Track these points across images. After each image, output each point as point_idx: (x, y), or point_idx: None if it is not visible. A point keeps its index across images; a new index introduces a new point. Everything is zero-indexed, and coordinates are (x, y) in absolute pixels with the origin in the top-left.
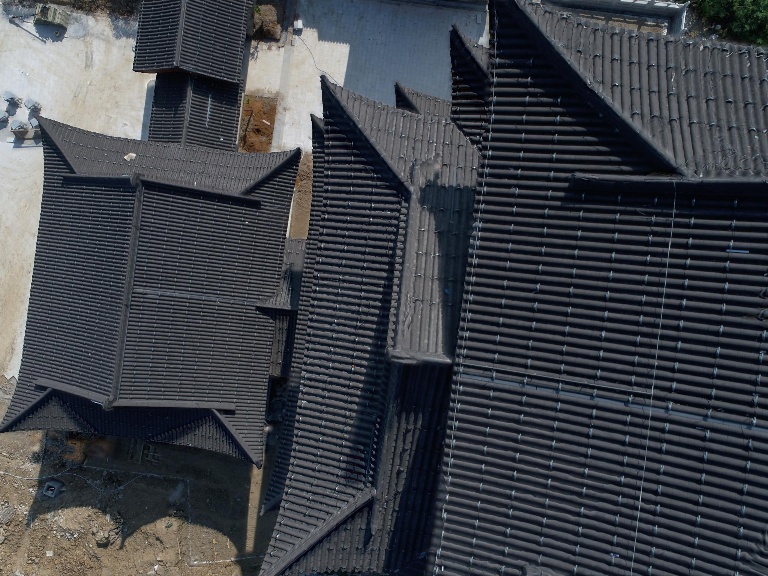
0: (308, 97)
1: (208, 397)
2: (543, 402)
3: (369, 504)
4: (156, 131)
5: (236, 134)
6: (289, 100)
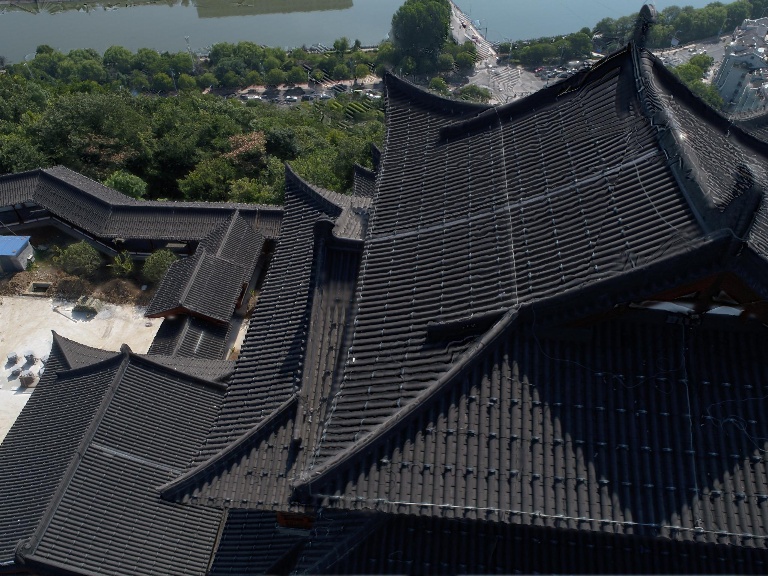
0: None
1: (134, 575)
2: None
3: (294, 411)
4: None
5: None
6: None
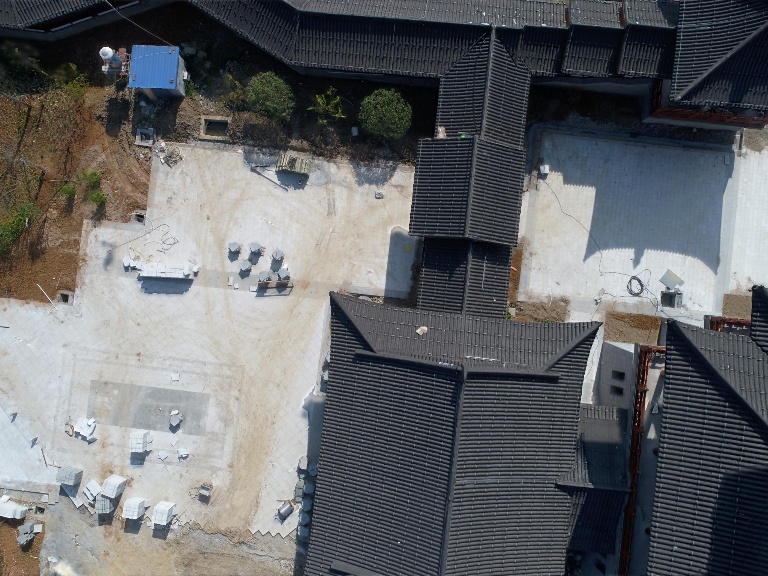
0: (554, 242)
1: None
2: None
3: None
4: (427, 292)
5: (507, 293)
6: (535, 245)
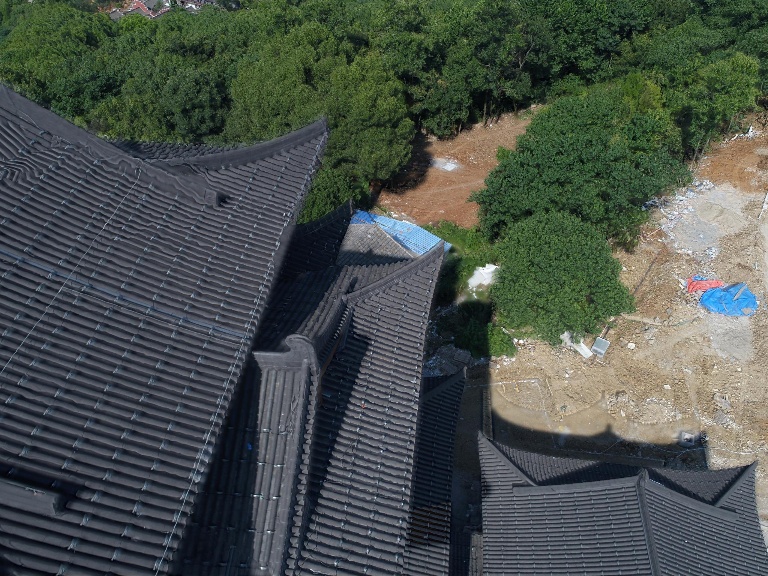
0: None
1: (544, 499)
2: (169, 303)
3: None
4: None
5: None
6: None
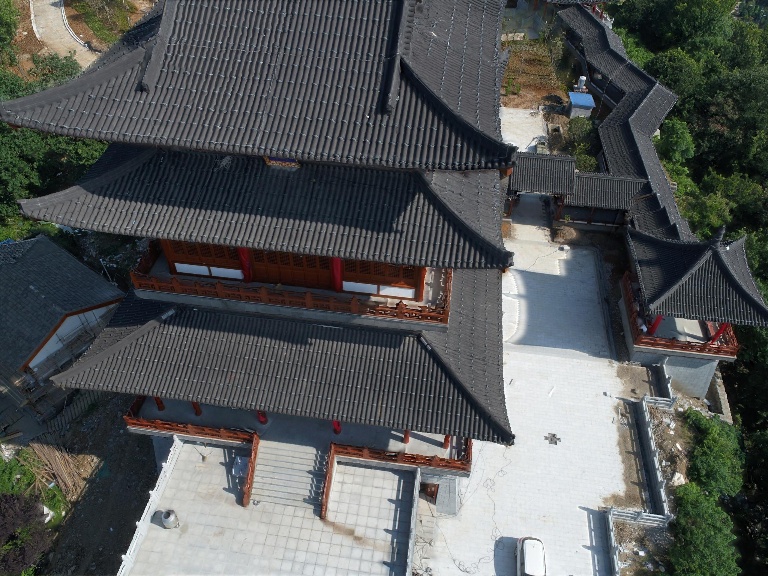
0: None
1: None
2: None
3: None
4: None
5: None
6: (511, 244)
